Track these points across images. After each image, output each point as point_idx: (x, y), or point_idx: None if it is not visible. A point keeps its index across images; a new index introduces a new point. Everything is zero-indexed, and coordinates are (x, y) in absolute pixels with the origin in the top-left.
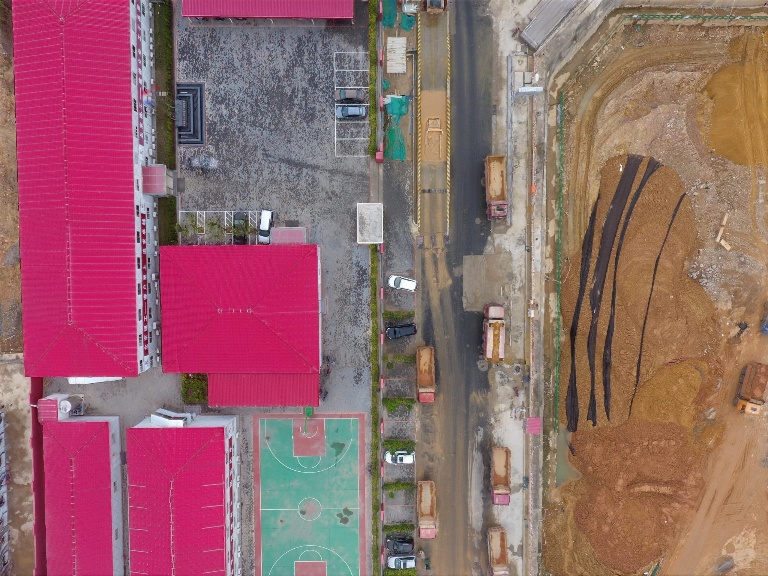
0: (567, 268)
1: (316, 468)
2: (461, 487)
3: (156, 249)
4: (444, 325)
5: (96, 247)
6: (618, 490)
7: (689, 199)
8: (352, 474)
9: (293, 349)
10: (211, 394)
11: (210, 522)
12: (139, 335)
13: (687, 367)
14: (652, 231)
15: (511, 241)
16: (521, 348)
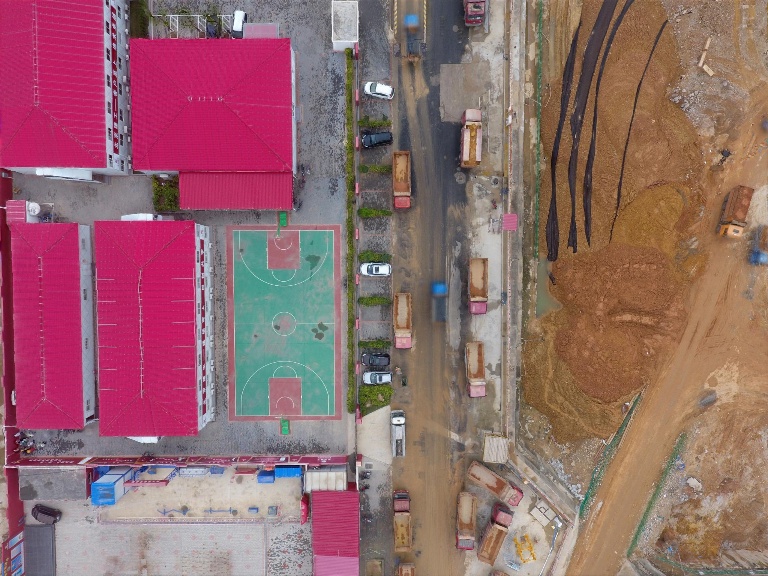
0: (548, 95)
1: (291, 281)
2: (438, 303)
3: (128, 54)
4: (421, 136)
5: (63, 29)
6: (598, 314)
7: (672, 26)
8: (327, 288)
9: (265, 143)
10: (183, 196)
11: (180, 317)
12: (108, 128)
13: (669, 189)
14: (634, 56)
15: (489, 49)
16: (499, 160)
